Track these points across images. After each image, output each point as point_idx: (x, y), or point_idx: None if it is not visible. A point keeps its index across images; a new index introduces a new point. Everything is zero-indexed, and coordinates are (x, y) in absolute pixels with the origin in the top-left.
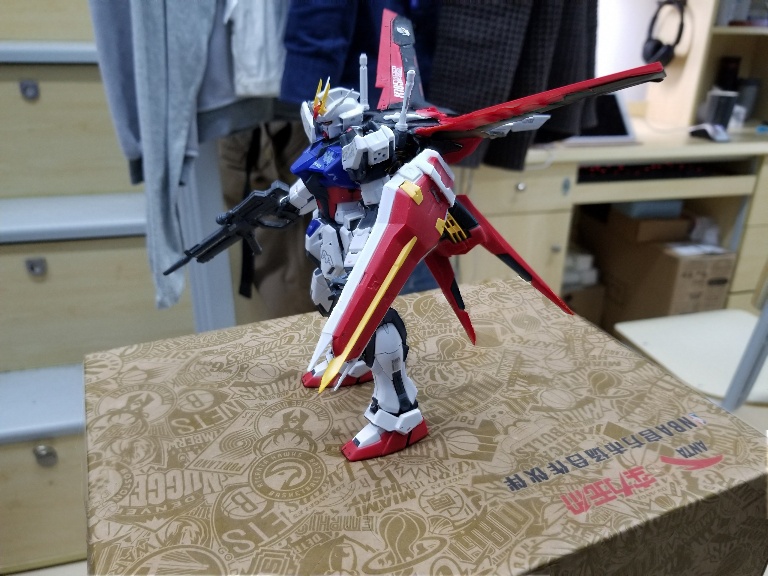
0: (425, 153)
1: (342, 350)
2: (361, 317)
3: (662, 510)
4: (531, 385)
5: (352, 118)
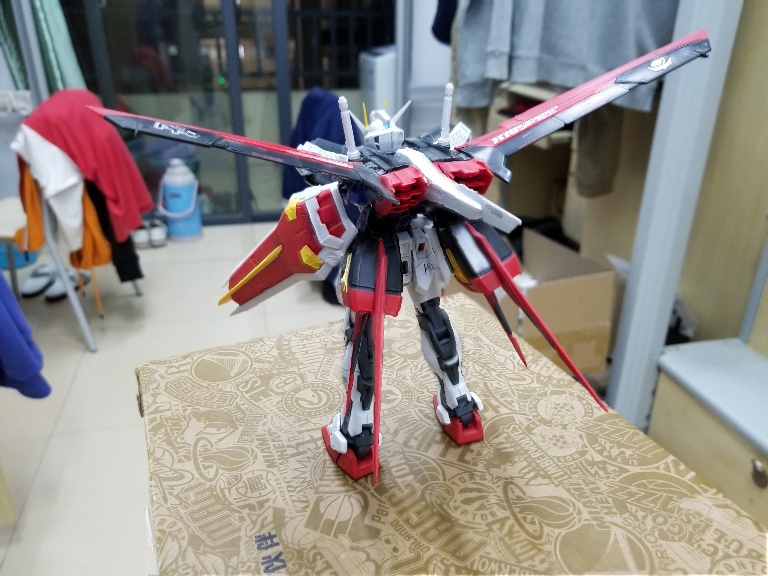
0: (333, 183)
1: None
2: None
3: None
4: None
5: None
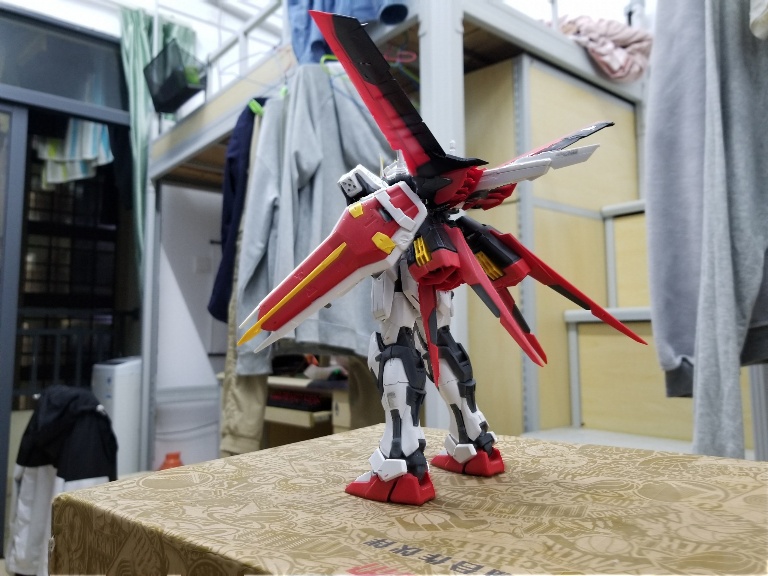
0: None
1: None
2: None
3: None
4: (606, 528)
5: (392, 177)
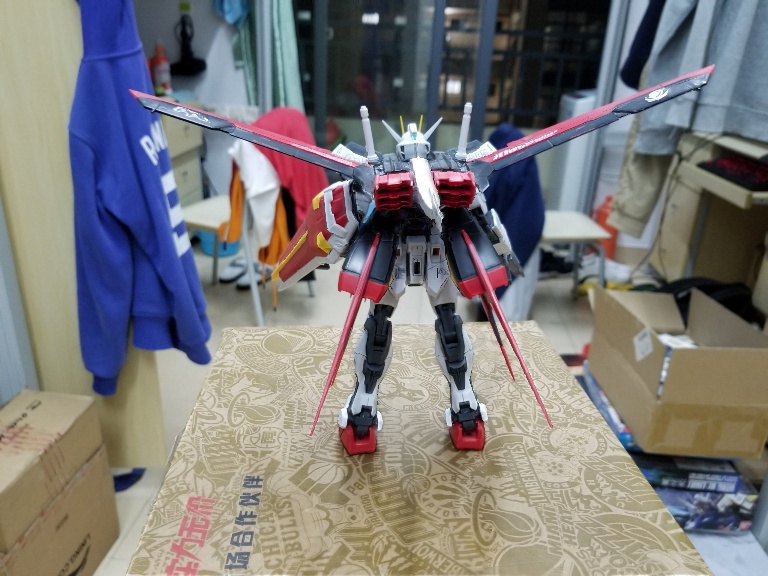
0: None
1: None
2: None
3: (135, 556)
4: (390, 569)
5: None
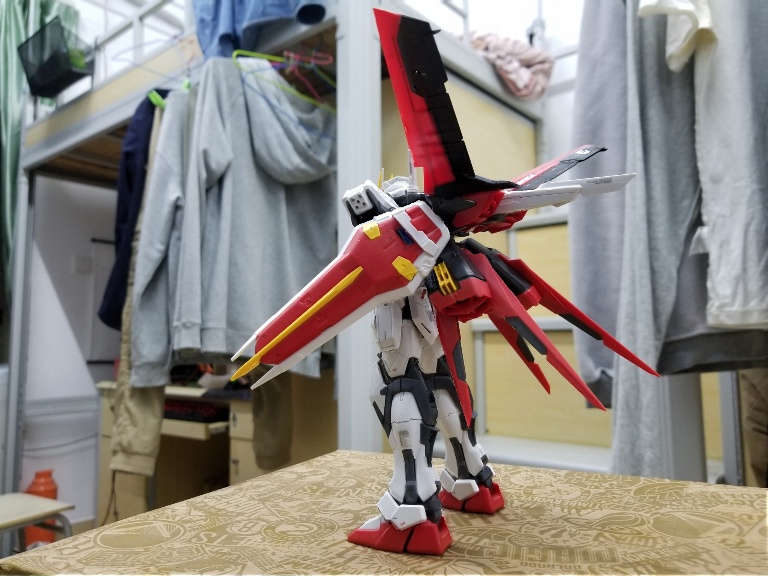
0: (412, 203)
1: (260, 349)
2: (287, 327)
3: None
4: (652, 575)
5: (395, 194)
